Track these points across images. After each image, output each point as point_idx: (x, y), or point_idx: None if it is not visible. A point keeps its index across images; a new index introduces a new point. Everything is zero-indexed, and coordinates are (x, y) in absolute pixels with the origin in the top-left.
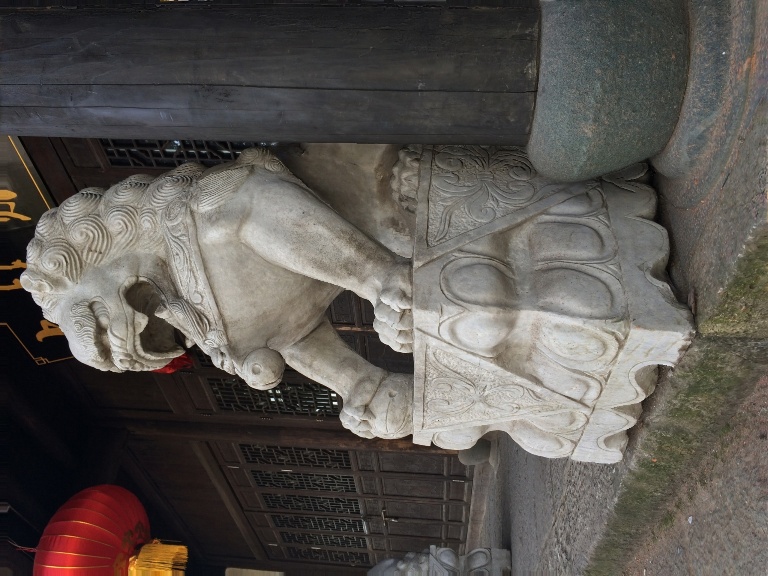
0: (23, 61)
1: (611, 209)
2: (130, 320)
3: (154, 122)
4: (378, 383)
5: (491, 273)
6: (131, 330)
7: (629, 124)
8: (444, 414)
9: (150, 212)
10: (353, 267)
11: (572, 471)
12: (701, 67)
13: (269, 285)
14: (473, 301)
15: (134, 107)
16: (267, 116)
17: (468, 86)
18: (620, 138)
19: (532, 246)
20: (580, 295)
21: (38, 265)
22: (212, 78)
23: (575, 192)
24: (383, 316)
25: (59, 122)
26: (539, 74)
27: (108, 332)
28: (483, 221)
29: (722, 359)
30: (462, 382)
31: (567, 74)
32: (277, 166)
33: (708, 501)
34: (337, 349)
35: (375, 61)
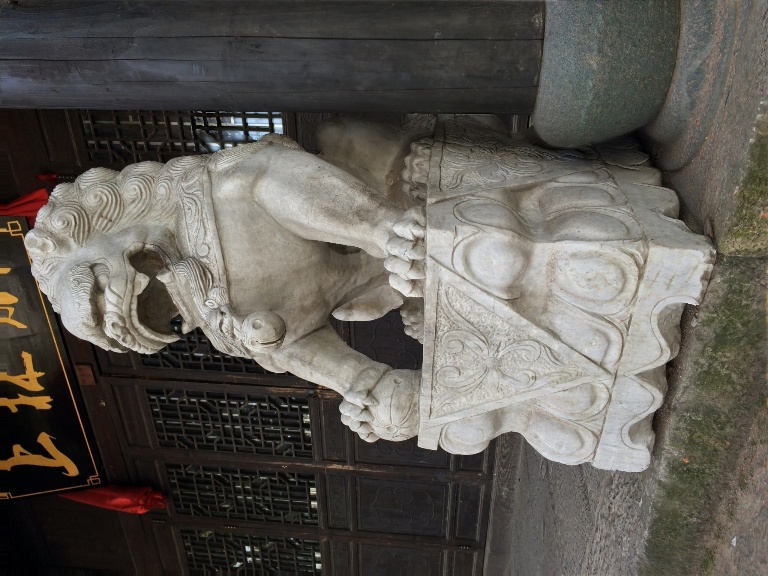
0: (75, 18)
1: (618, 178)
2: (131, 278)
3: (186, 76)
4: (382, 372)
5: (504, 208)
6: (130, 288)
7: (631, 59)
8: (454, 392)
9: (167, 179)
10: (365, 214)
11: (591, 559)
12: (691, 8)
13: (278, 247)
14: (488, 224)
15: (170, 59)
16: (293, 67)
17: (481, 35)
18: (623, 74)
19: (543, 205)
20: (595, 223)
21: (46, 224)
22: (246, 30)
23: (581, 169)
24: (395, 246)
25: (96, 78)
26: (545, 23)
27: (106, 288)
28: (494, 181)
29: (747, 292)
30: (475, 337)
31: (571, 10)
32: (295, 145)
33: (752, 504)
34: (340, 347)
35: (396, 14)
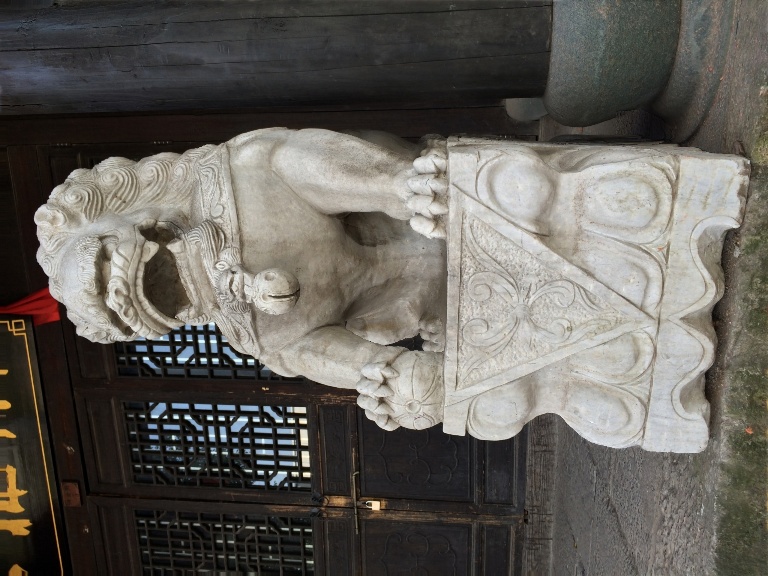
0: (112, 12)
1: None
2: (140, 243)
3: (212, 58)
4: (402, 349)
5: None
6: (138, 252)
7: (638, 11)
8: (482, 352)
9: (185, 161)
10: (384, 167)
11: None
12: None
13: (294, 214)
14: None
15: (198, 41)
16: (315, 43)
17: (493, 5)
18: (632, 24)
19: (564, 163)
20: (620, 150)
21: (59, 199)
22: (271, 13)
23: None
24: (417, 179)
25: (126, 64)
26: None
27: (113, 252)
28: None
29: None
30: (503, 280)
31: None
32: None
33: None
34: (355, 337)
35: None
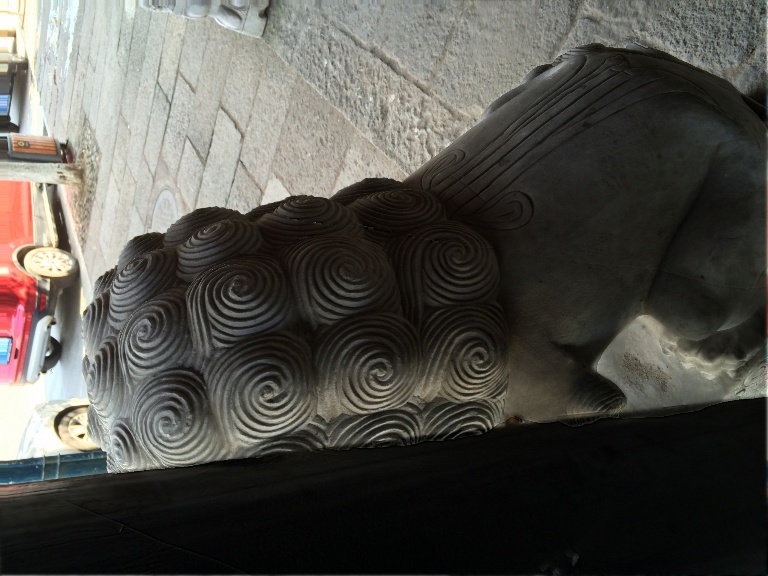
0: None
1: None
2: None
3: None
4: None
5: None
6: None
7: None
8: None
9: None
10: None
11: None
12: None
13: None
14: None
15: None
16: None
17: None
18: None
19: None
20: None
21: None
22: None
23: None
24: None
25: None
26: None
27: None
28: None
29: None
30: None
31: None
32: None
33: None
34: None
35: None
